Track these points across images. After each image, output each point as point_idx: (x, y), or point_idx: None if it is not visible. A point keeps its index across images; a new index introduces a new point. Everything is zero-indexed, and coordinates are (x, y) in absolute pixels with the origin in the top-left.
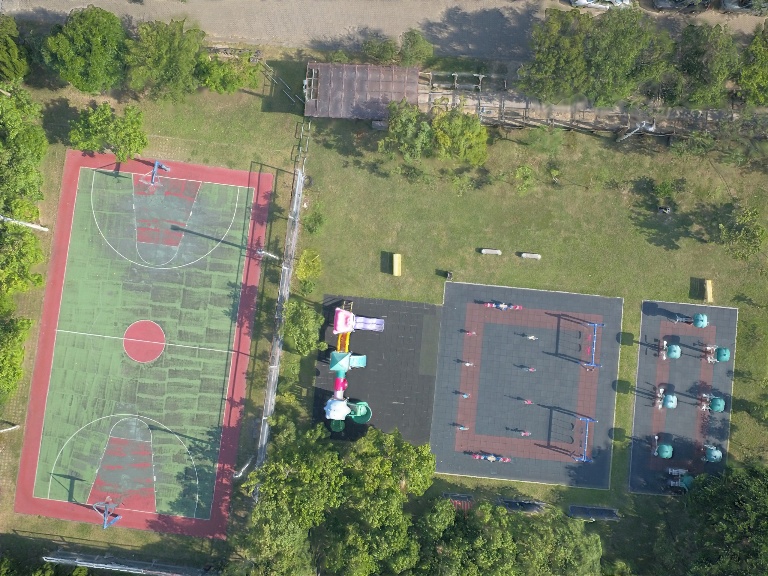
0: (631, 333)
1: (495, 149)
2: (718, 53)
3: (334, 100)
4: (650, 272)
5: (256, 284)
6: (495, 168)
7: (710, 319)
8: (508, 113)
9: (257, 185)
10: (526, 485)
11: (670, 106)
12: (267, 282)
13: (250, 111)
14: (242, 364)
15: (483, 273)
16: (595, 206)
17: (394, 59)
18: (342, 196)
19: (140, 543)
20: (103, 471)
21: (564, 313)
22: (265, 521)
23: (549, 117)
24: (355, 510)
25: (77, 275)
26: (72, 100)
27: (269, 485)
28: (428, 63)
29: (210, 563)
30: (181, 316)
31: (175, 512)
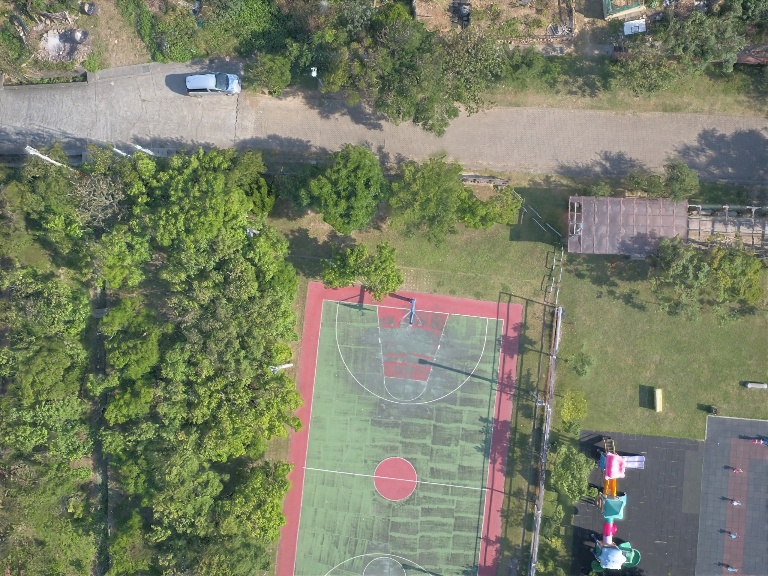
0: None
1: None
2: None
3: (599, 235)
4: None
5: (508, 419)
6: None
7: None
8: None
9: (506, 316)
10: None
11: None
12: (520, 417)
13: (498, 240)
14: (496, 502)
15: (747, 407)
16: None
17: None
18: (597, 328)
19: None
20: None
21: None
22: None
23: None
24: None
25: (324, 411)
26: (312, 231)
27: None
28: None
29: None
30: (432, 453)
31: None
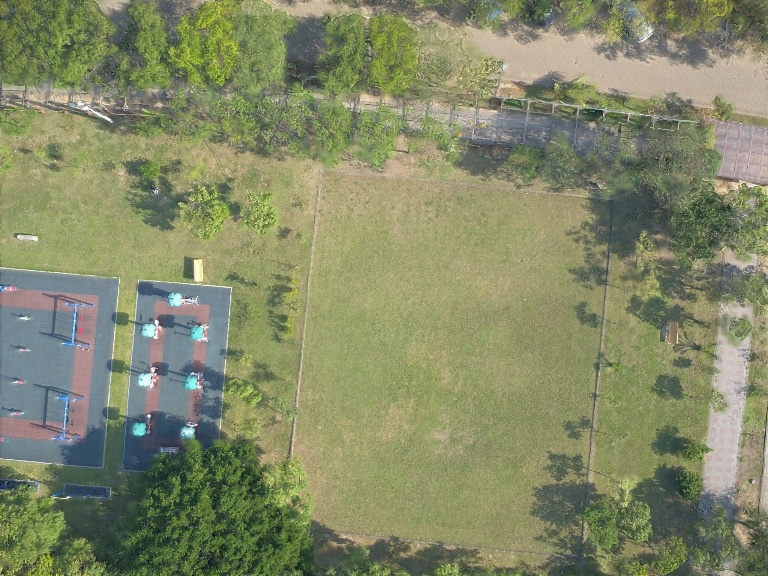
0: (126, 313)
1: None
2: (143, 32)
3: None
4: (145, 252)
5: None
6: None
7: (204, 298)
8: (8, 96)
9: None
10: (21, 464)
11: (122, 86)
12: None
13: None
14: None
15: None
16: (93, 187)
17: None
18: None
19: None
20: None
21: (61, 293)
22: None
23: (47, 99)
24: None
25: None
26: None
27: None
28: None
29: None
30: None
31: None
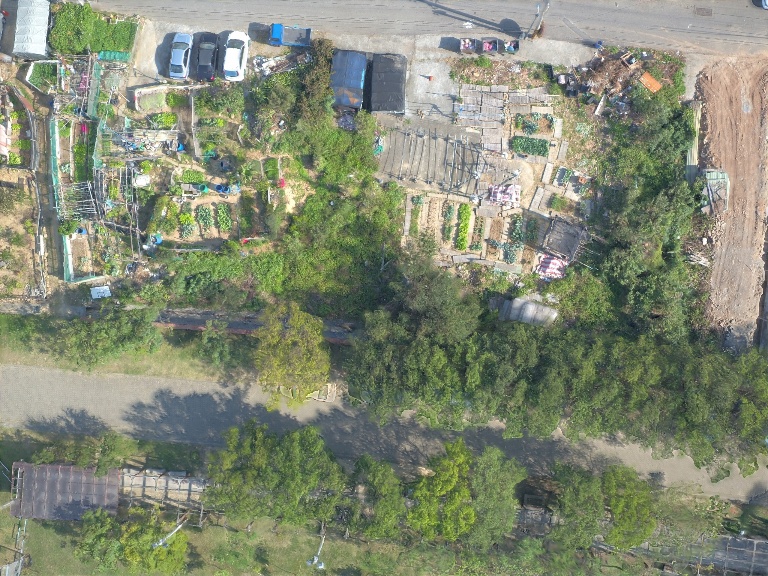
0: None
1: (207, 534)
2: (383, 498)
3: (37, 501)
4: None
5: None
6: (207, 553)
7: None
8: None
9: None
10: None
11: None
12: None
13: None
14: None
15: None
16: None
17: None
18: (60, 575)
19: None
20: None
21: None
22: None
23: None
24: None
25: None
26: None
27: None
28: (143, 447)
29: None
30: None
31: None
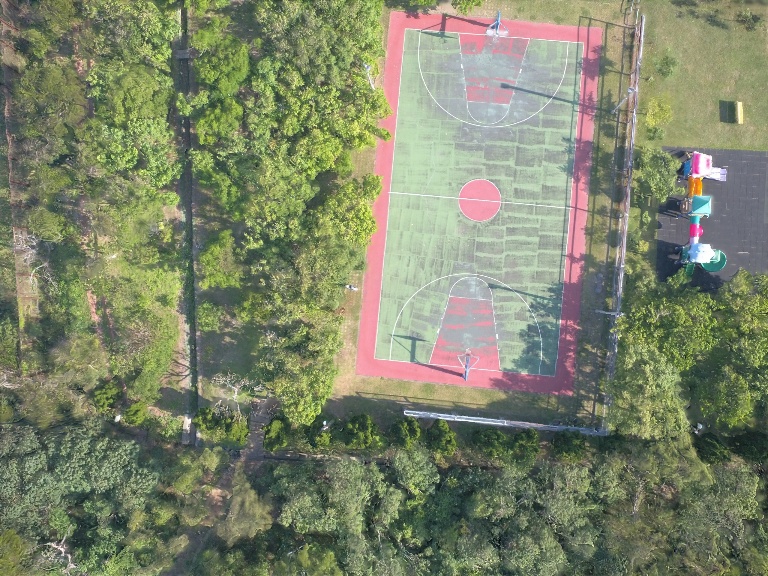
0: None
1: None
2: None
3: None
4: None
5: (590, 139)
6: None
7: None
8: None
9: (587, 40)
10: None
11: None
12: (602, 137)
13: None
14: (580, 220)
15: None
16: None
17: None
18: (676, 47)
19: (485, 401)
20: (444, 331)
21: None
22: (643, 362)
23: None
24: (703, 362)
25: (408, 137)
26: None
27: (639, 329)
28: None
29: (557, 419)
30: (516, 174)
31: (519, 369)
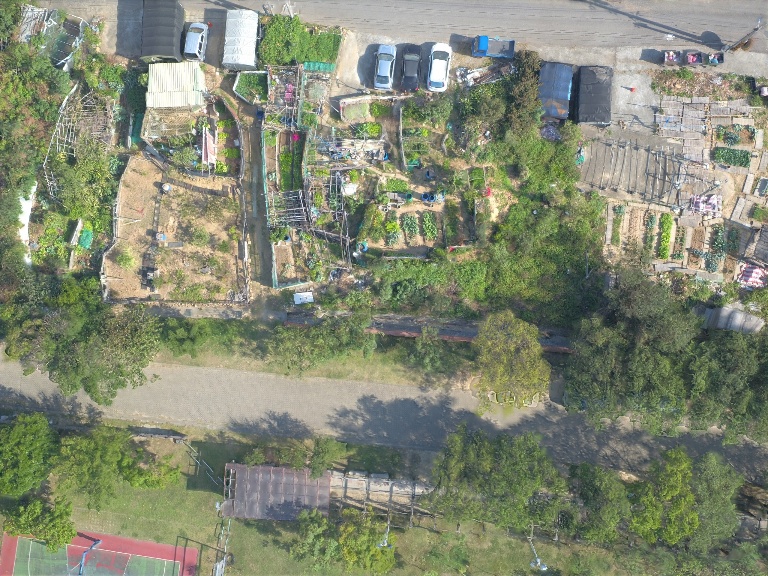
0: None
1: (408, 535)
2: (610, 502)
3: (250, 501)
4: None
5: None
6: (408, 553)
7: None
8: None
9: (183, 559)
10: None
11: (568, 533)
12: None
13: (176, 489)
14: None
15: None
16: None
17: (308, 460)
18: (262, 574)
19: None
20: None
21: None
22: None
23: None
24: None
25: None
26: None
27: None
28: None
29: None
30: None
31: None
